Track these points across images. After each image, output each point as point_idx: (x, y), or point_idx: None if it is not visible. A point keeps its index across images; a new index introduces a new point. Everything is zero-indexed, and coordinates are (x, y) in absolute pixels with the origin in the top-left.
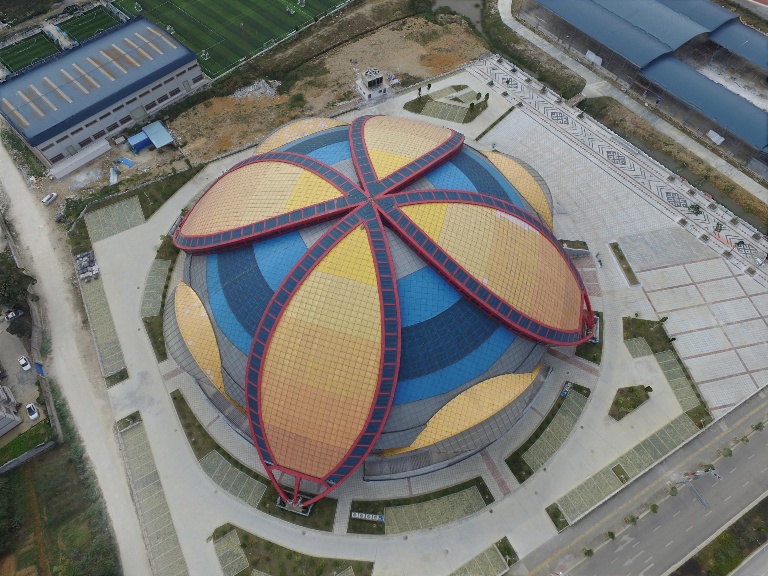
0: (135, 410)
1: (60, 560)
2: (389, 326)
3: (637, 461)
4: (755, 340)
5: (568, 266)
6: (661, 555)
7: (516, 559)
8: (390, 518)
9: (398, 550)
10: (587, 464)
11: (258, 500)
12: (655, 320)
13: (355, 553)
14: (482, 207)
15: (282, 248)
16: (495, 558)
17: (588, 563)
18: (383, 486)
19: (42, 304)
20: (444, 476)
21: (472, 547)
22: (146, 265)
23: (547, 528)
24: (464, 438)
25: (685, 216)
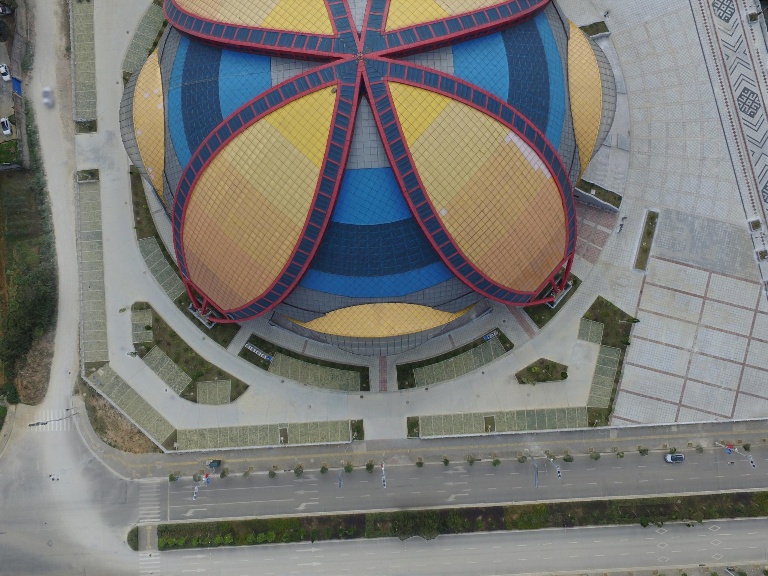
0: (95, 167)
1: (13, 267)
2: (316, 216)
3: (511, 422)
4: (715, 381)
5: (566, 225)
6: (479, 492)
7: (361, 438)
8: (277, 361)
9: (272, 387)
10: (466, 403)
11: (176, 296)
12: (630, 314)
13: (238, 372)
14: (494, 120)
15: (247, 71)
16: (345, 430)
17: (417, 468)
18: (283, 335)
19: (31, 9)
20: (338, 352)
21: (331, 413)
22: (142, 6)
23: (400, 430)
24: (351, 342)
25: (765, 218)
